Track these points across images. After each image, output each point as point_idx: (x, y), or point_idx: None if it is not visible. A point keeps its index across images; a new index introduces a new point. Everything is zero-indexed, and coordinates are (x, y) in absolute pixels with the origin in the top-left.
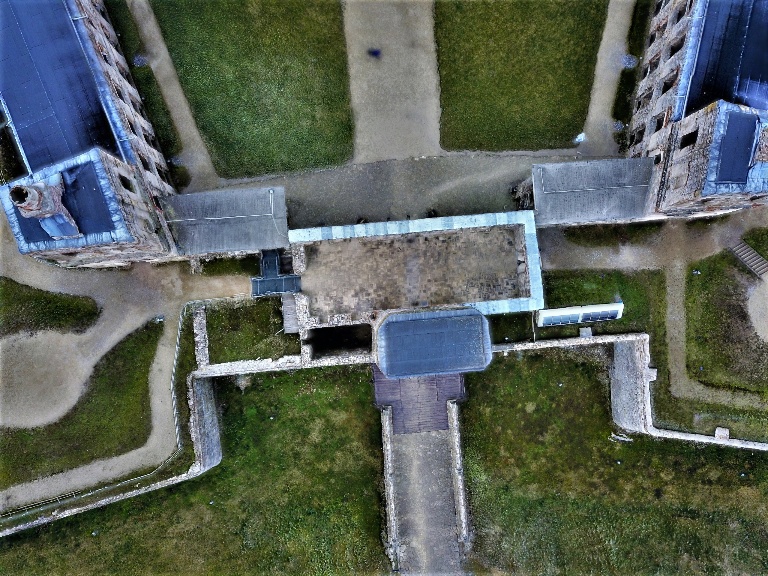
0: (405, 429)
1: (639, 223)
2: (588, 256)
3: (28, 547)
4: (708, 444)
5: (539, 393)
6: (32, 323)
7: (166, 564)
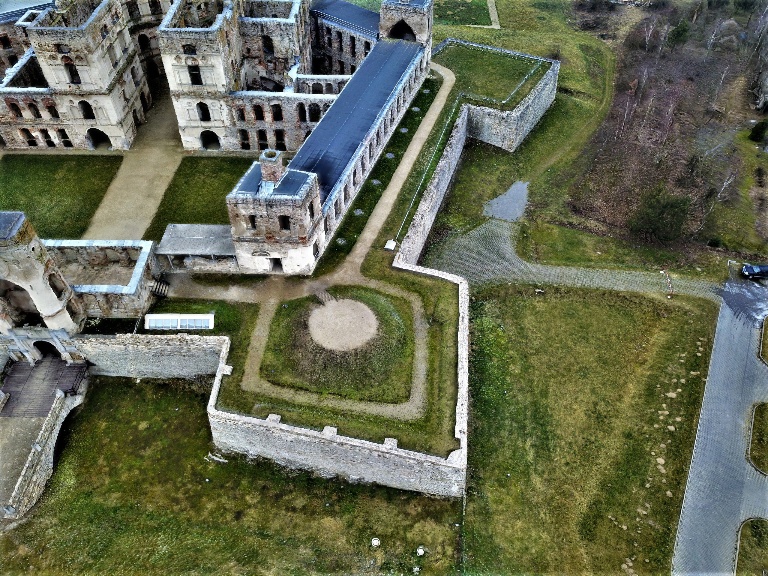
0: (11, 414)
1: (249, 275)
2: (204, 291)
3: None
4: (300, 473)
5: (156, 415)
6: None
7: None
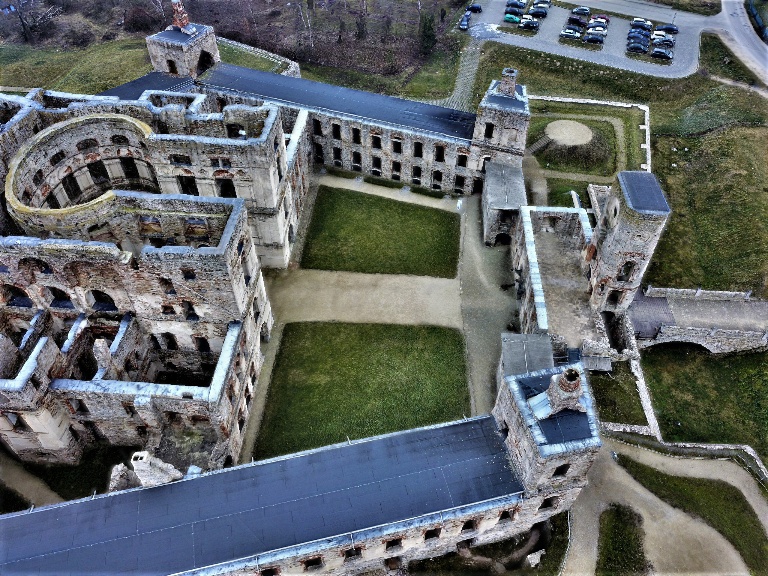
0: (672, 322)
1: None
2: (539, 205)
3: None
4: None
5: None
6: (637, 568)
7: None
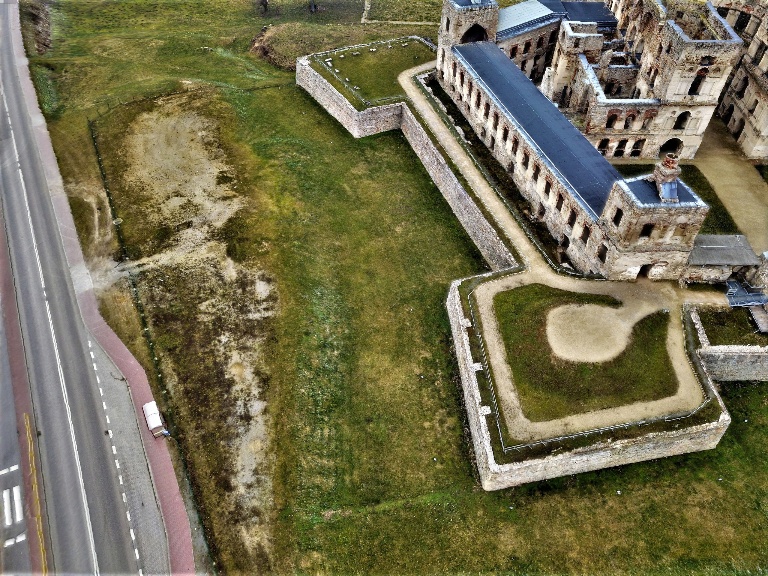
0: None
1: None
2: None
3: (559, 497)
4: None
5: None
6: (577, 301)
7: (697, 528)
